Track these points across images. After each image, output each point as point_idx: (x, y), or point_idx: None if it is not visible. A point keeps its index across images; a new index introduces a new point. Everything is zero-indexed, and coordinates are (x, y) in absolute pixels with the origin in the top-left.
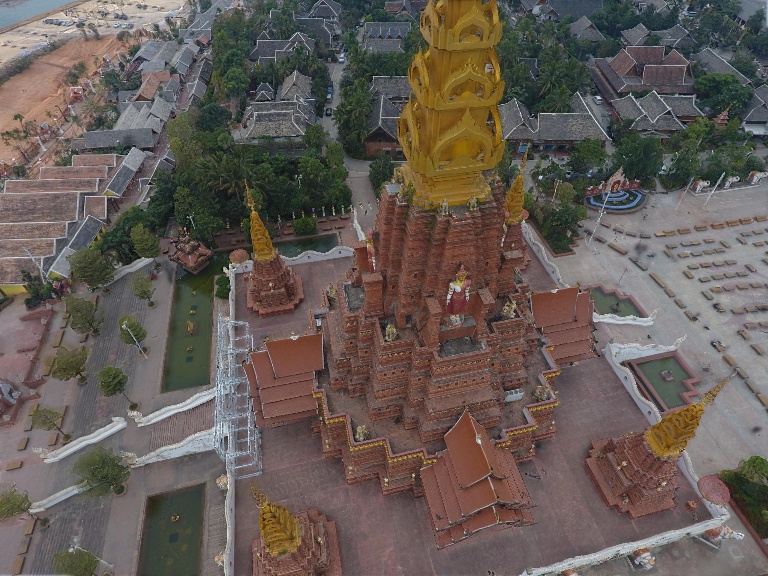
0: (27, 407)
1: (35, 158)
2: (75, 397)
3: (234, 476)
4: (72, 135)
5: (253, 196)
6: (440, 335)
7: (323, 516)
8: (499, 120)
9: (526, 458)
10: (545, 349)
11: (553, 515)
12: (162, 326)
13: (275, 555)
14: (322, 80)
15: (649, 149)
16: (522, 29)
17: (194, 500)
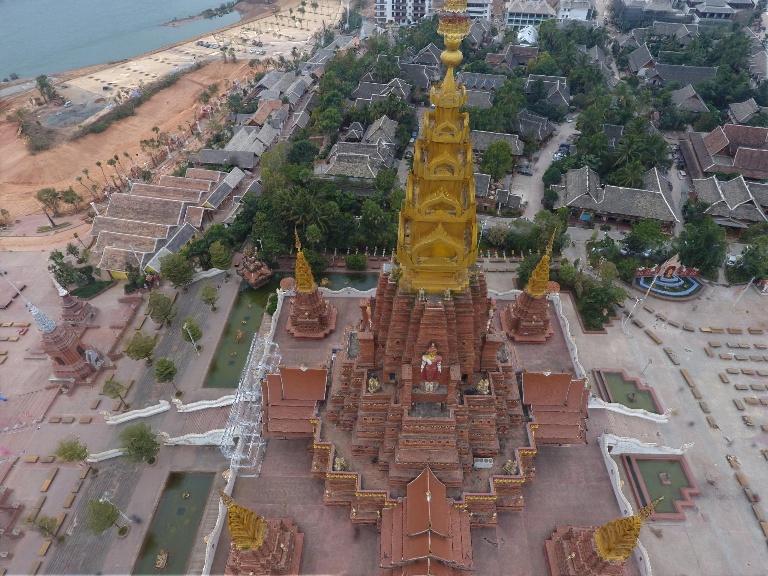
0: (105, 375)
1: (162, 163)
2: (141, 375)
3: (236, 473)
4: (193, 148)
5: (313, 231)
6: (414, 396)
7: (296, 527)
8: (475, 231)
9: (489, 524)
10: (528, 426)
11: None
12: (217, 330)
13: (240, 548)
14: (408, 125)
15: (711, 240)
16: (618, 93)
17: (204, 484)
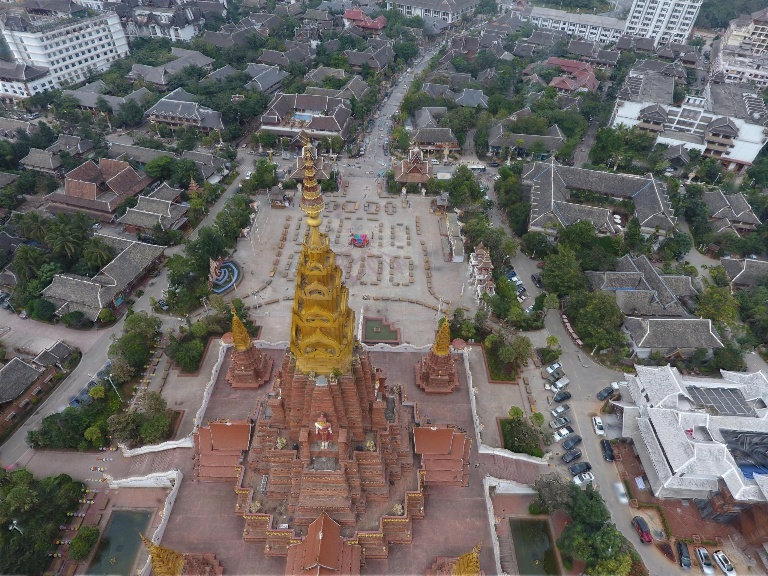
0: None
1: None
2: None
3: None
4: None
5: None
6: None
7: (433, 565)
8: None
9: None
10: None
11: (450, 422)
12: None
13: None
14: None
15: (210, 236)
16: None
17: None
